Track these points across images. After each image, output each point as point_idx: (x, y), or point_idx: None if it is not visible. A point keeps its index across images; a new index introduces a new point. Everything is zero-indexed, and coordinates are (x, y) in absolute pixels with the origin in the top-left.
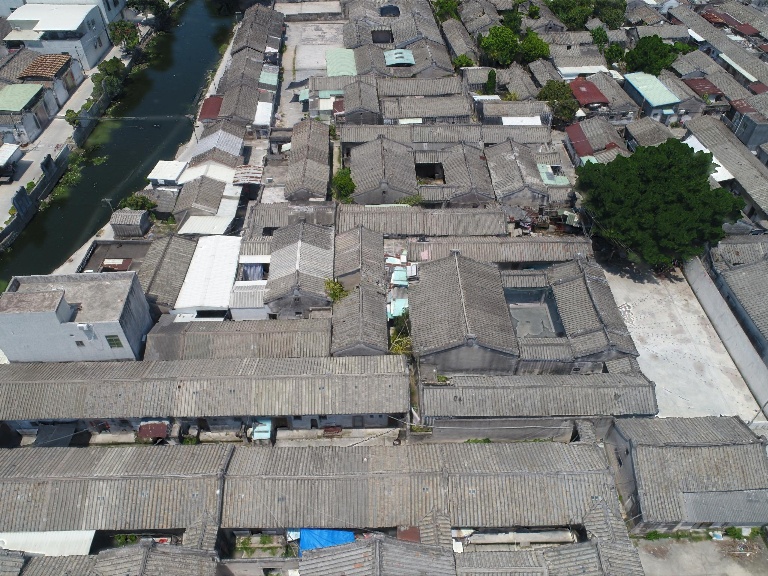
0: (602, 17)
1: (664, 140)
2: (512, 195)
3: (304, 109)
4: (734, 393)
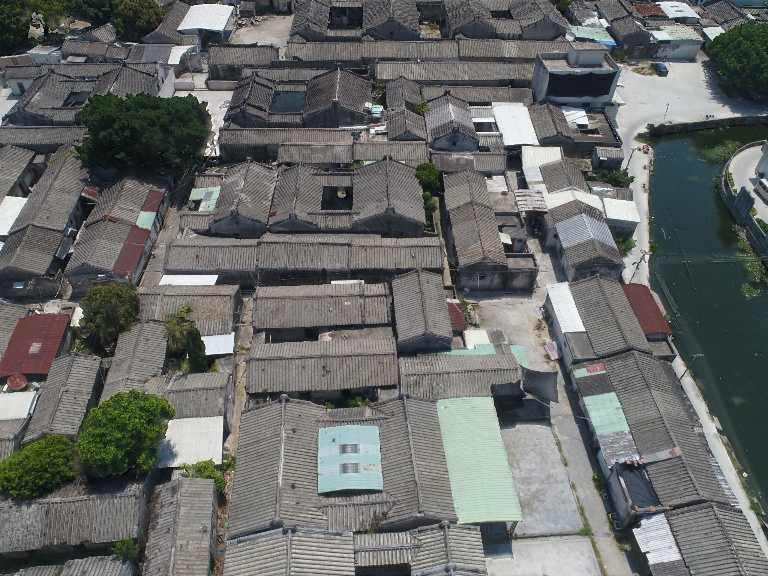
0: None
1: (35, 226)
2: None
3: None
4: None
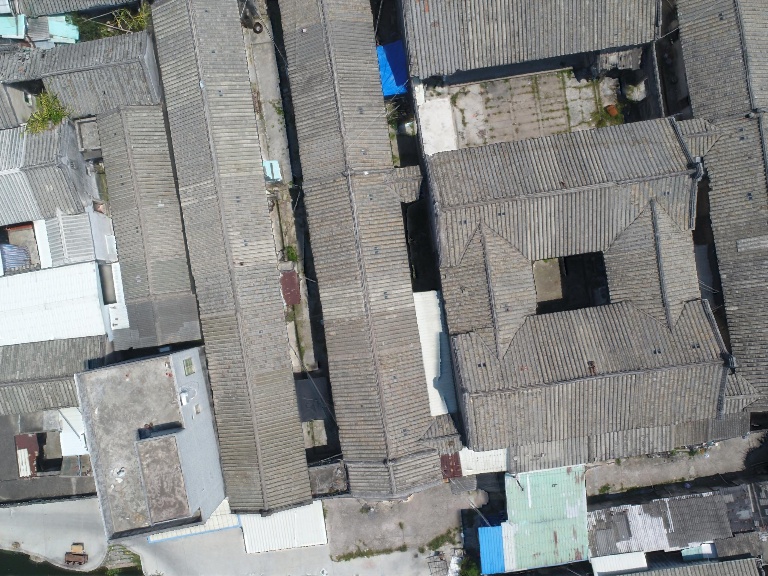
0: None
1: None
2: None
3: None
4: None
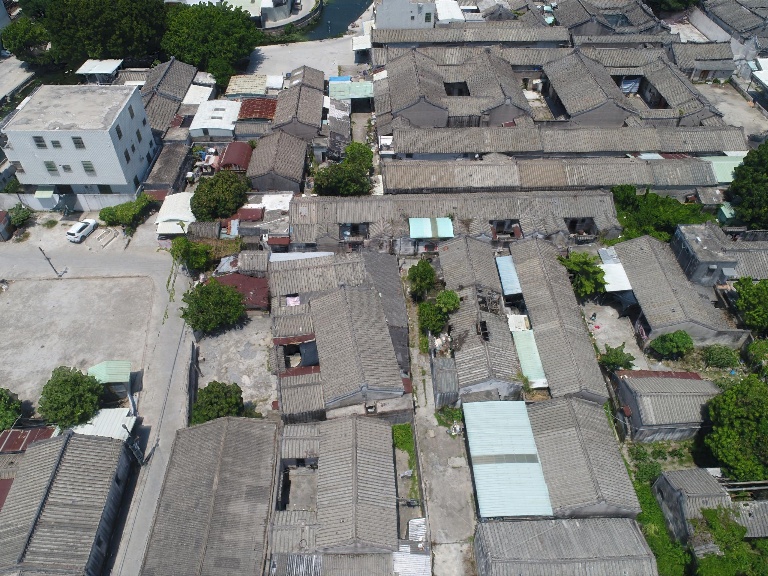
0: None
1: None
2: None
3: None
4: None
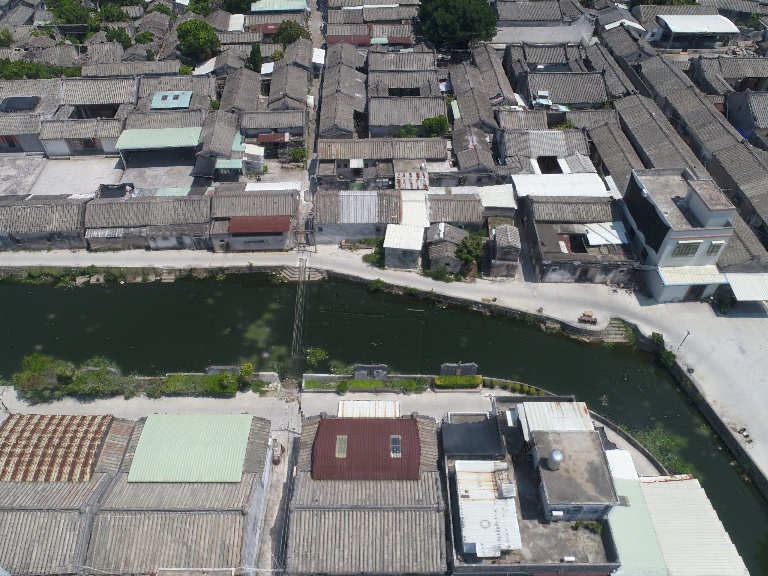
0: (127, 3)
1: (362, 10)
2: None
3: (233, 180)
4: None
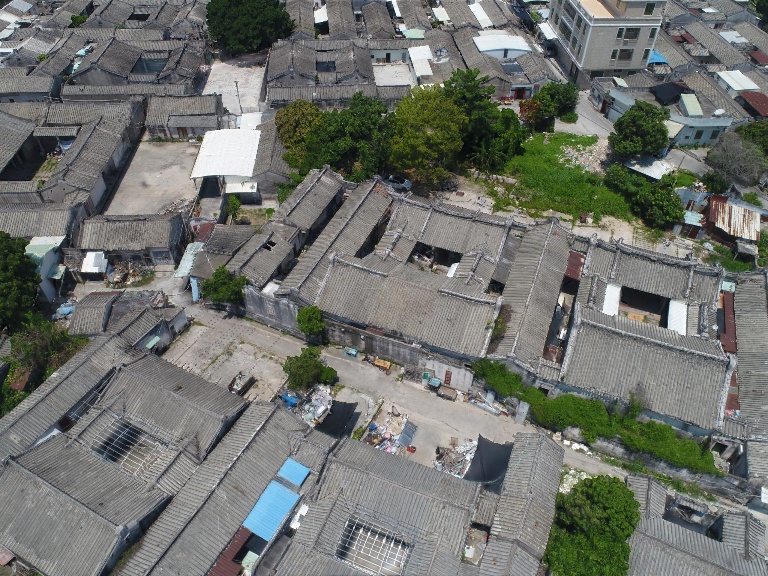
0: None
1: None
2: (179, 25)
3: None
4: (252, 103)
